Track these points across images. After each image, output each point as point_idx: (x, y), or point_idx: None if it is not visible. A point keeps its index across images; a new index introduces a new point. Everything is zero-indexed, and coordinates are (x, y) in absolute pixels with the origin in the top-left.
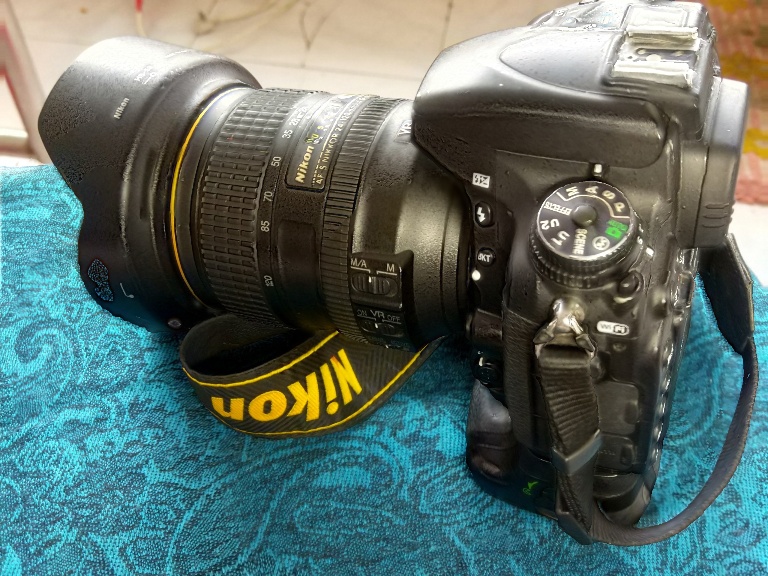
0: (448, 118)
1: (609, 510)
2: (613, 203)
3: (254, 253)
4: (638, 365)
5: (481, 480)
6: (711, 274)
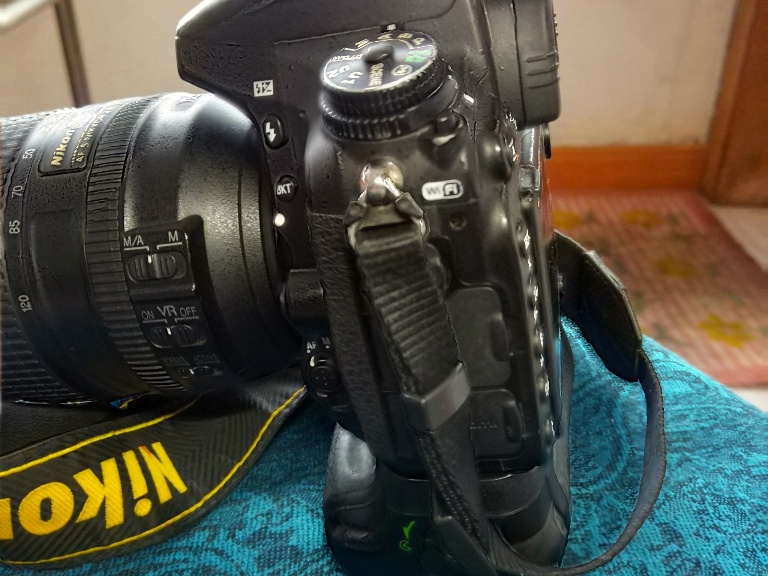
0: (216, 28)
1: (514, 540)
2: (411, 40)
3: (2, 266)
4: (488, 248)
5: (348, 559)
6: (583, 309)
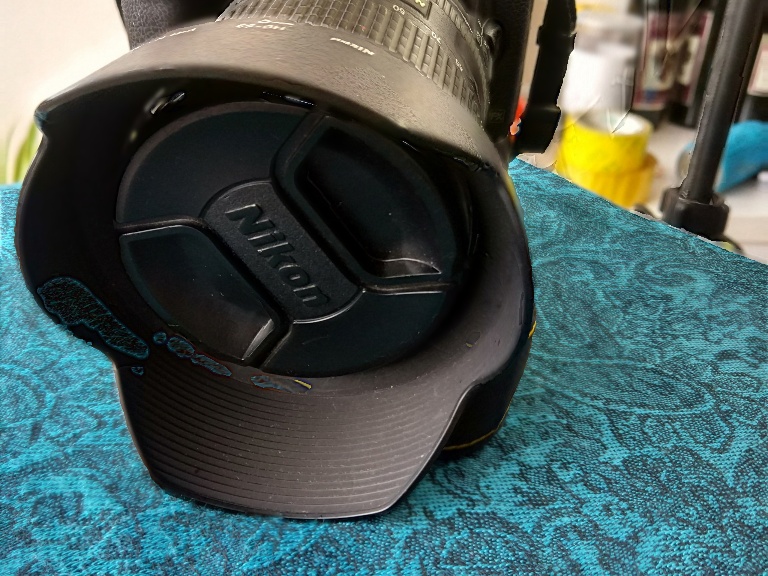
0: None
1: None
2: None
3: None
4: None
5: None
6: None
